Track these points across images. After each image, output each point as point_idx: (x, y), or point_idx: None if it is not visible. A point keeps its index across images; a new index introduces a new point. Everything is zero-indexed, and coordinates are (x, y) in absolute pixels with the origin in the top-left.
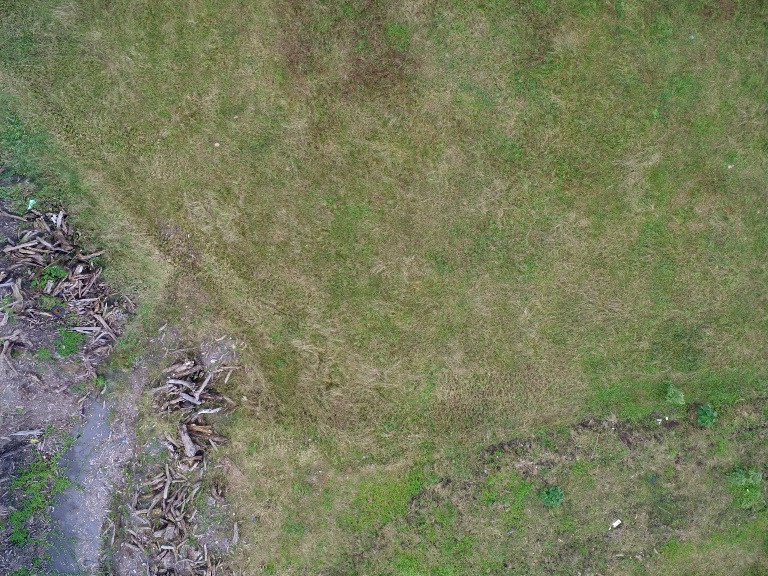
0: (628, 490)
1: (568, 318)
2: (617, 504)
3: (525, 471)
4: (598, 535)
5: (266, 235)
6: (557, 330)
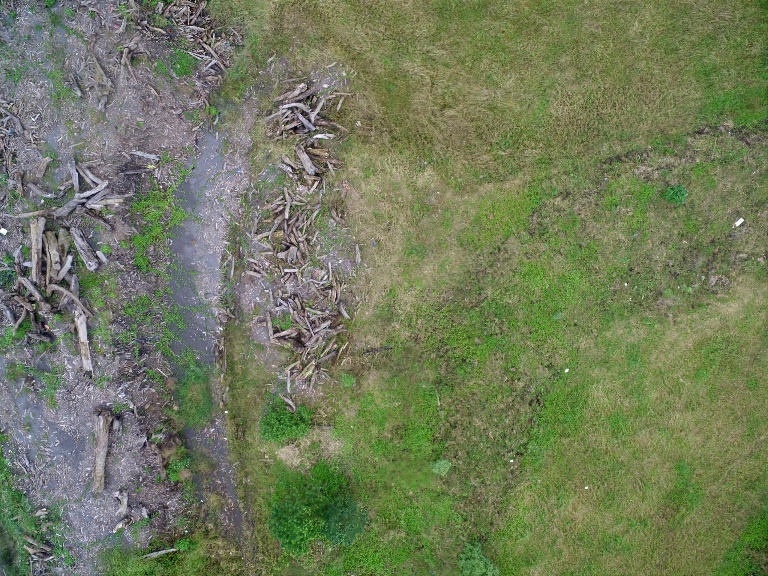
0: (750, 187)
1: (679, 27)
2: (739, 202)
3: (645, 177)
4: (721, 236)
5: None
6: (668, 40)
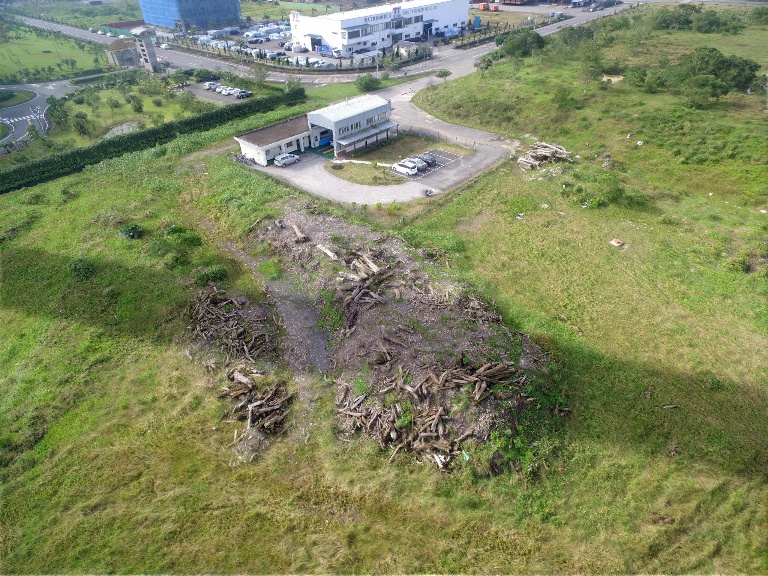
0: None
1: None
2: None
3: None
4: None
5: (248, 572)
6: None
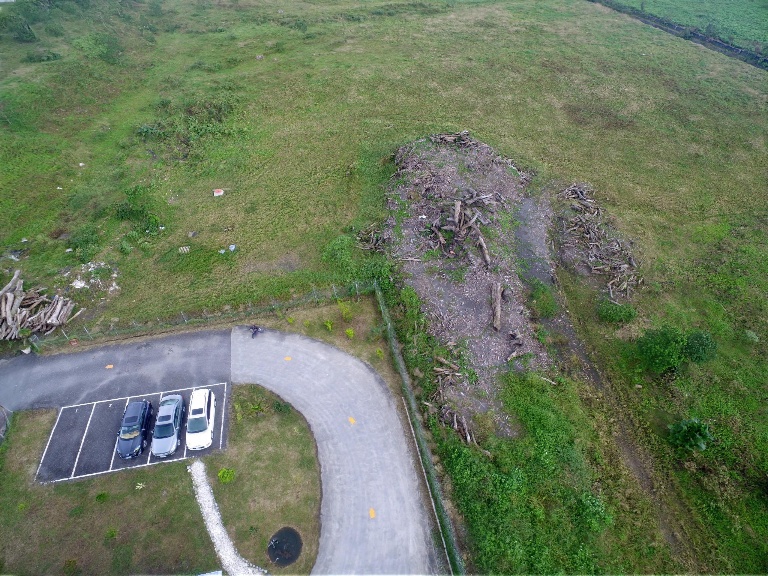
0: None
1: (763, 178)
2: None
3: None
4: None
5: None
6: (760, 182)
